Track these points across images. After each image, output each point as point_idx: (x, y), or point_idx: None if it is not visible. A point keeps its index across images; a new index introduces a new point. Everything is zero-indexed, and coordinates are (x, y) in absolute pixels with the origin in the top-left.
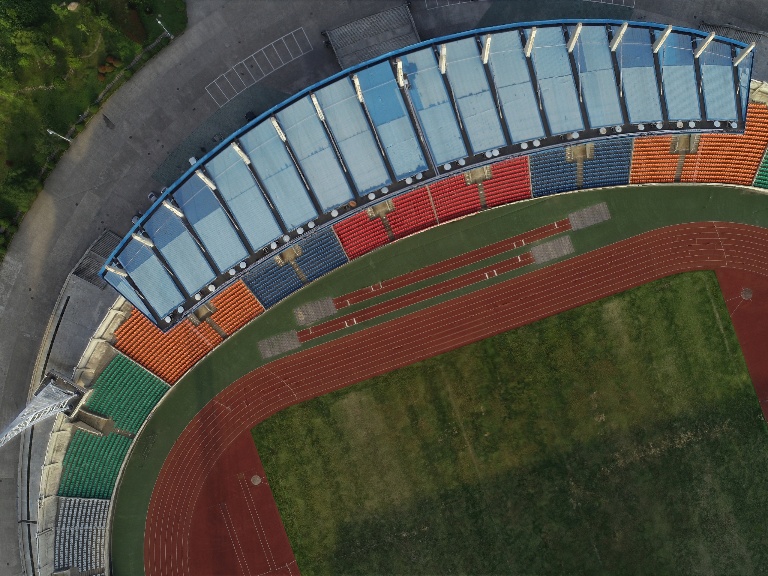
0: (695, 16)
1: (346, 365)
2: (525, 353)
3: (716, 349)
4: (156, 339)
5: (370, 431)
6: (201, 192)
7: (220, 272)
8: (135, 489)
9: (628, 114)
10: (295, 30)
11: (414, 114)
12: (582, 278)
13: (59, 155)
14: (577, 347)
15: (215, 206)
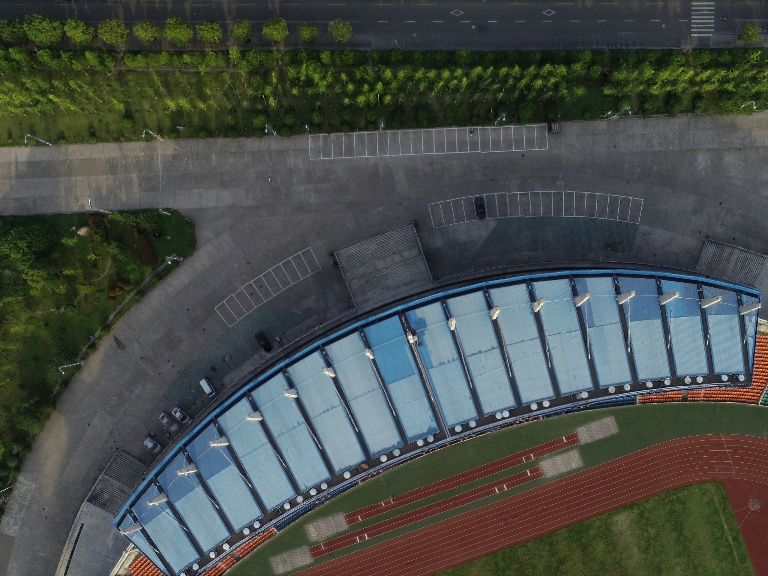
0: (700, 231)
1: None
2: (535, 566)
3: (725, 560)
4: None
5: None
6: (214, 447)
7: (234, 530)
8: None
9: (636, 371)
10: (303, 250)
11: (424, 373)
12: (591, 491)
13: (71, 377)
14: (587, 559)
15: (228, 462)
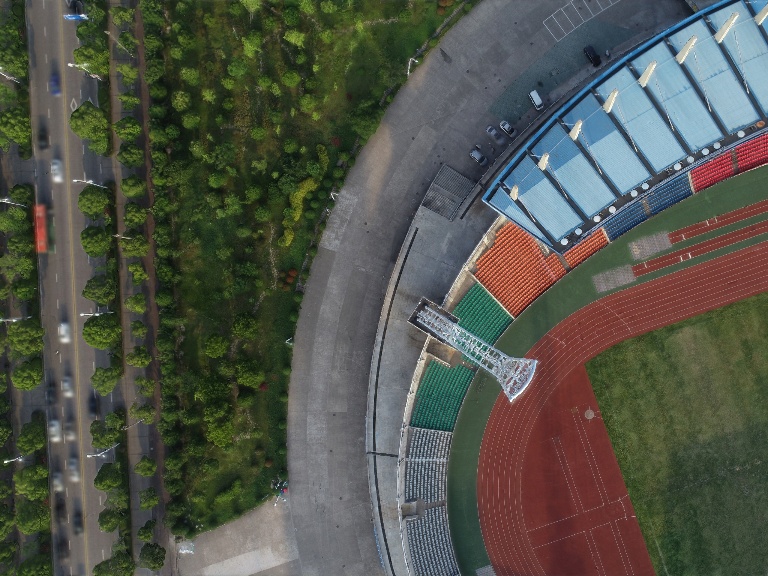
0: None
1: (681, 299)
2: None
3: None
4: (509, 270)
5: (704, 365)
6: (594, 115)
7: (620, 194)
8: (469, 423)
9: None
10: None
11: None
12: None
13: (397, 89)
14: None
15: (610, 129)
